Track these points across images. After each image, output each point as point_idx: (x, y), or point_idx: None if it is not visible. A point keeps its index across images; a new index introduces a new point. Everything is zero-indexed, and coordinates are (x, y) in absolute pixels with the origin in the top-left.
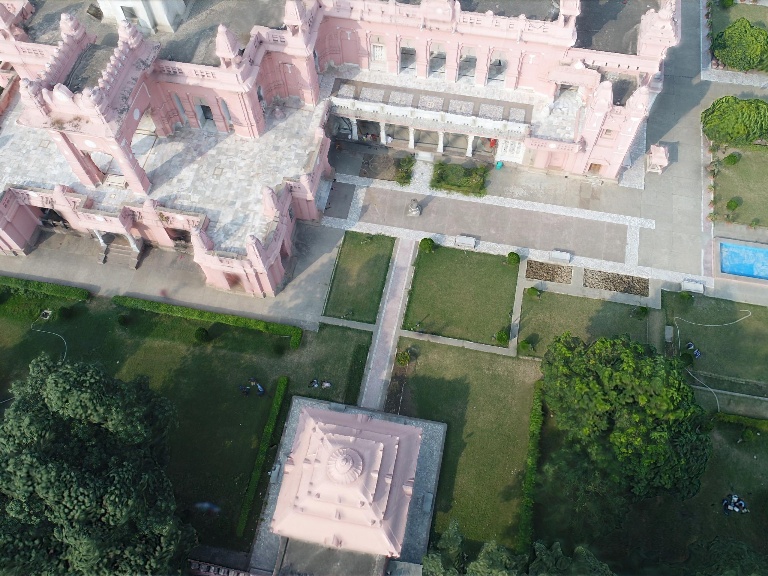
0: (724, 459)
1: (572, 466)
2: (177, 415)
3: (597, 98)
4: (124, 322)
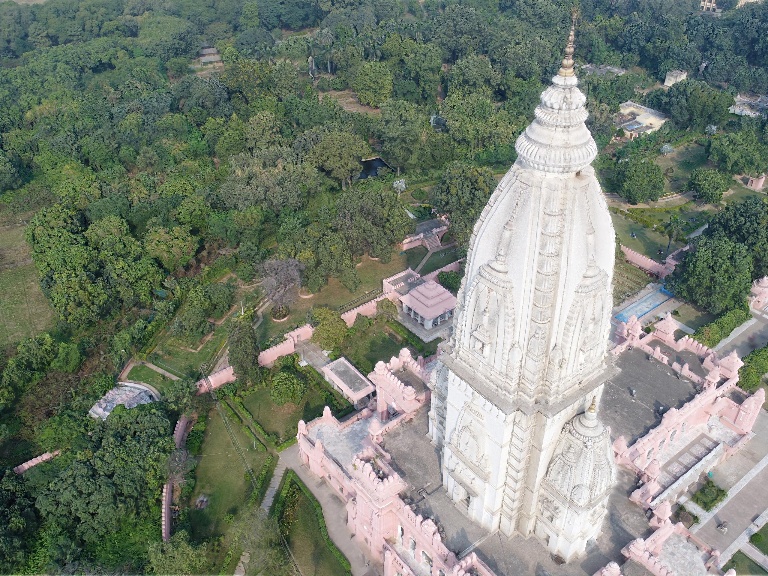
0: None
1: None
2: None
3: (751, 407)
4: None
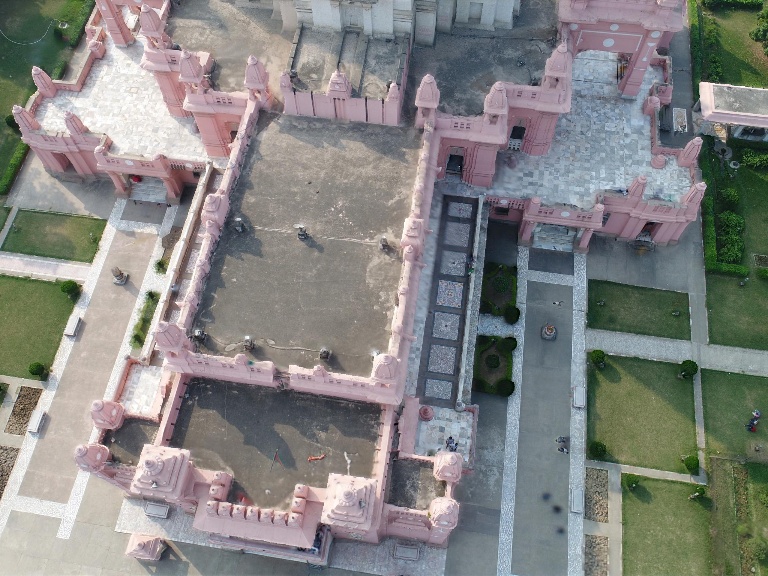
0: None
1: None
2: None
3: None
4: None
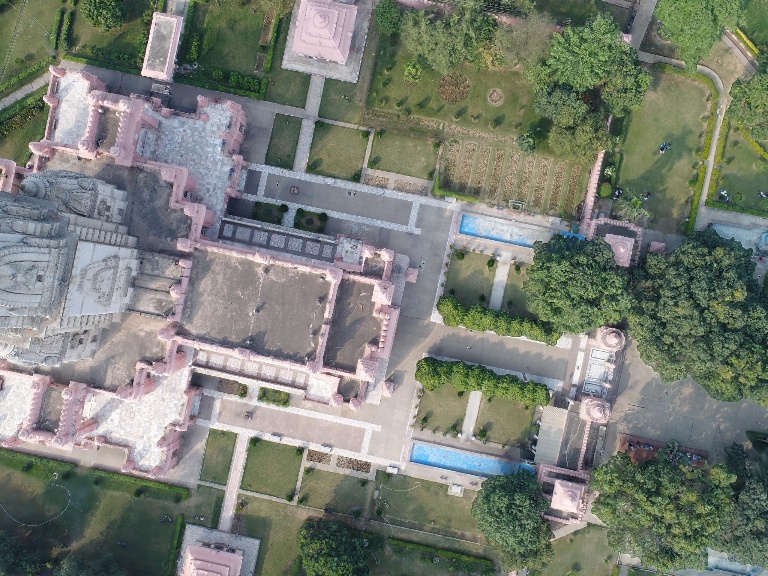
0: (389, 559)
1: None
2: (126, 574)
3: None
4: None
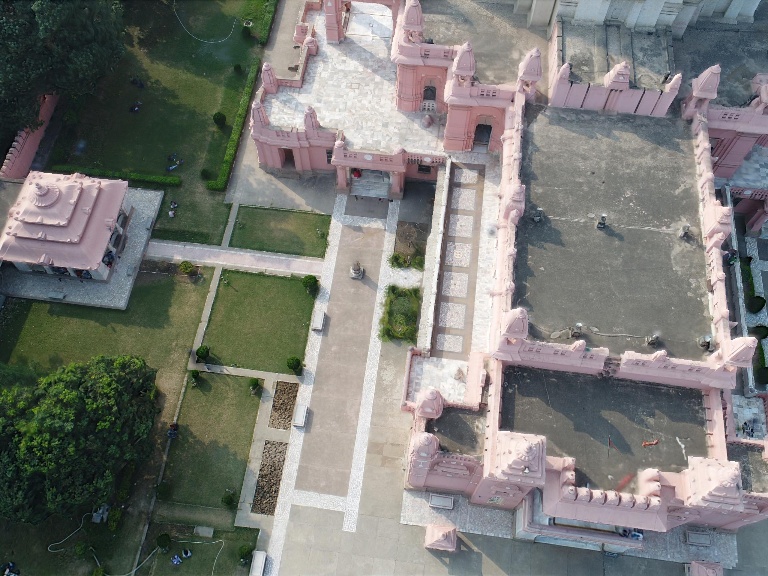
0: (57, 573)
1: (28, 380)
2: (87, 73)
3: None
4: (237, 69)
